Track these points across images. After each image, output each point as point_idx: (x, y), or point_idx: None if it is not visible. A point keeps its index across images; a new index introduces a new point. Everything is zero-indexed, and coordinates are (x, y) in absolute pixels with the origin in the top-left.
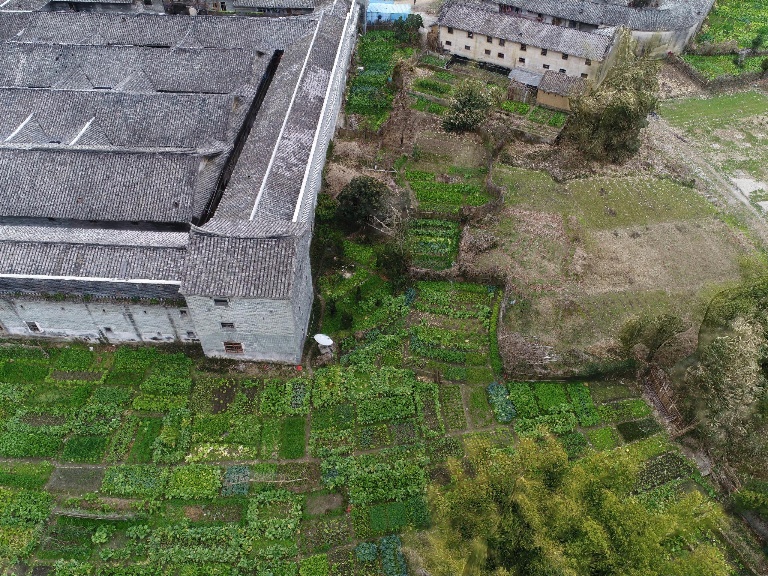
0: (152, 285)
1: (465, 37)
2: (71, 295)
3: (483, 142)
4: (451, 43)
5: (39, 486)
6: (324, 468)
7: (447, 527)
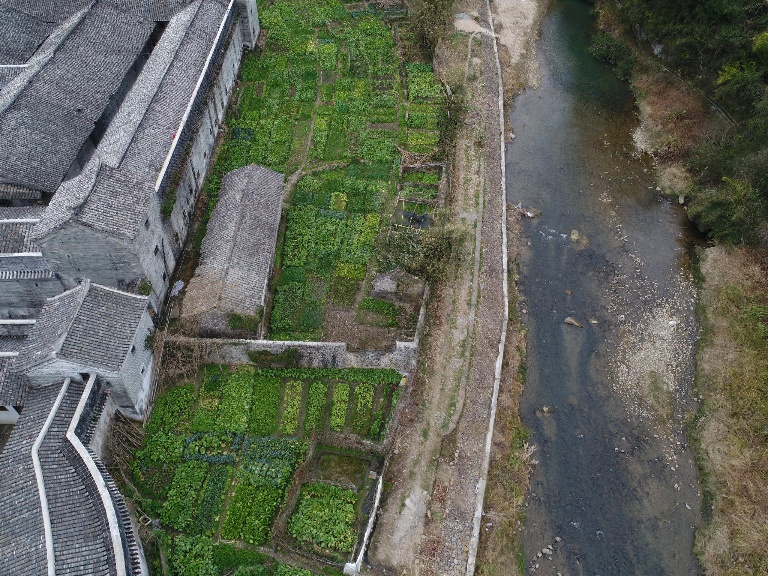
0: None
1: None
2: None
3: None
4: None
5: None
6: (321, 23)
7: (344, 6)
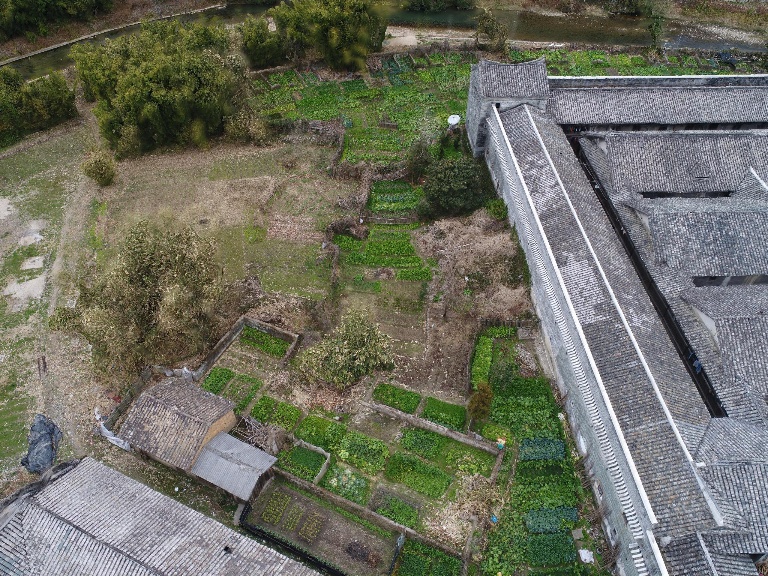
0: None
1: None
2: None
3: None
4: None
5: None
6: None
7: None
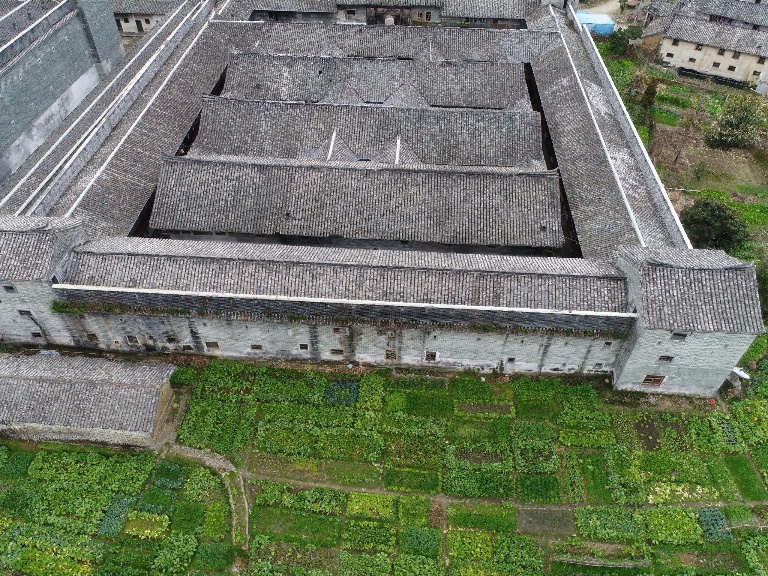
0: (594, 317)
1: (692, 49)
2: (499, 326)
3: (756, 159)
4: (673, 55)
5: (513, 529)
6: None
7: None
